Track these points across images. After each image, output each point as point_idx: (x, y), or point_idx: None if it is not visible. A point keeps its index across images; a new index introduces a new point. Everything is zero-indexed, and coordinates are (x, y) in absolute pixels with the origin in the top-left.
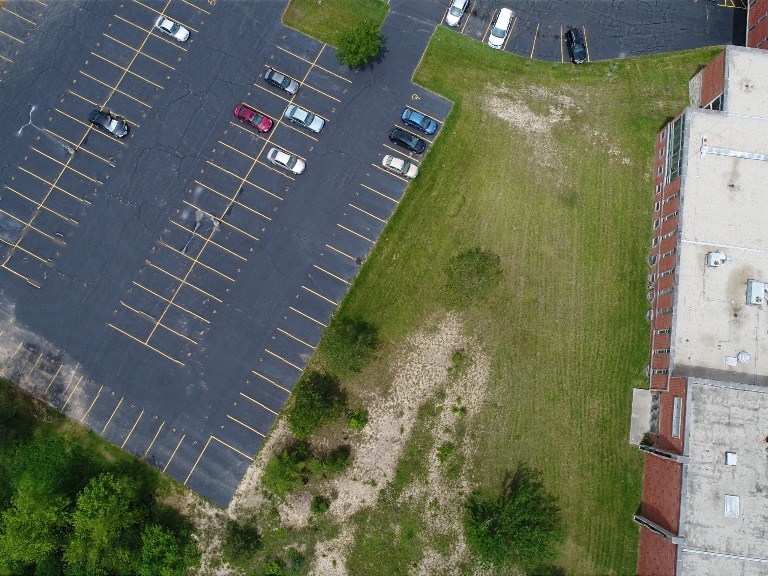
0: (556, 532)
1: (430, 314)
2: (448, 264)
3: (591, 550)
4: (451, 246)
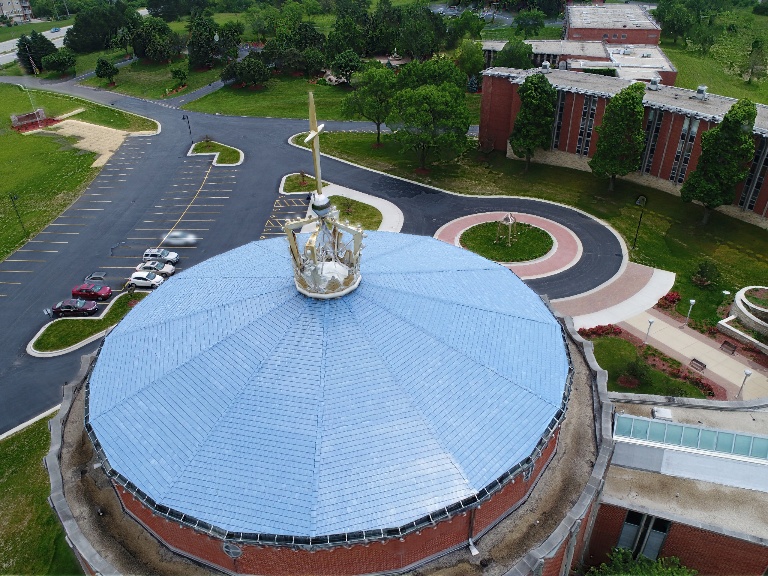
0: (679, 52)
1: (761, 84)
2: (767, 74)
3: (664, 50)
4: (764, 93)
